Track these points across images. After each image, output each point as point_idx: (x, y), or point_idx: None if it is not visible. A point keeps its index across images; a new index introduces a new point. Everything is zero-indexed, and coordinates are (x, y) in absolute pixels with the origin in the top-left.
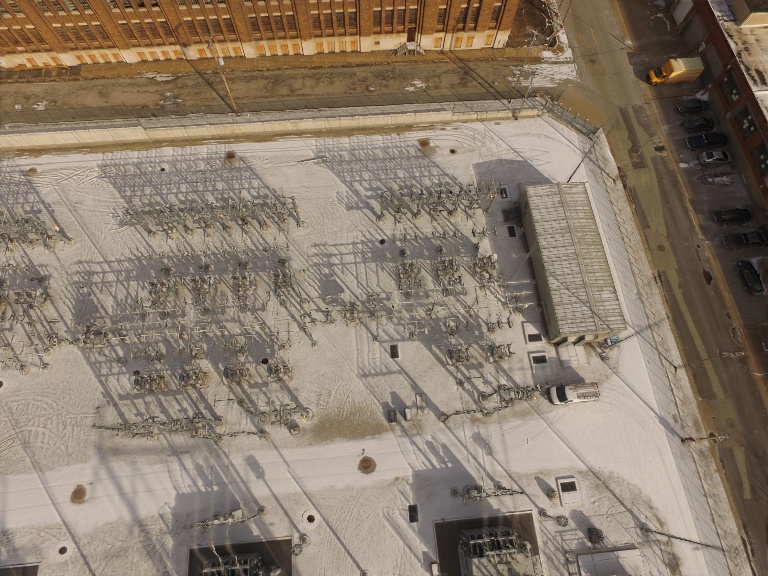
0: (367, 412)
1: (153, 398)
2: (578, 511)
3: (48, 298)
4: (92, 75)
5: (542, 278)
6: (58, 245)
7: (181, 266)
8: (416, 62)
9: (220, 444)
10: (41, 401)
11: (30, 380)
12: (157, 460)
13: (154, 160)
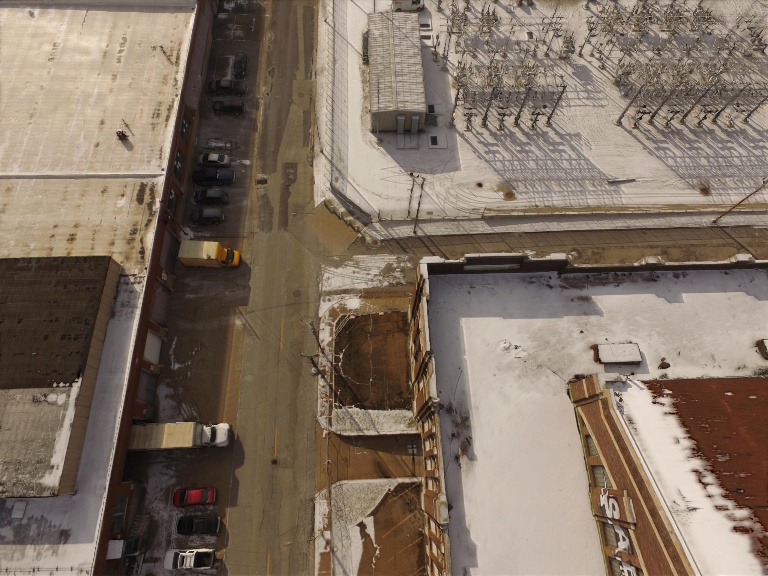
0: (546, 6)
1: None
2: None
3: None
4: None
5: None
6: None
7: None
8: None
9: None
10: (766, 24)
11: None
12: None
13: None
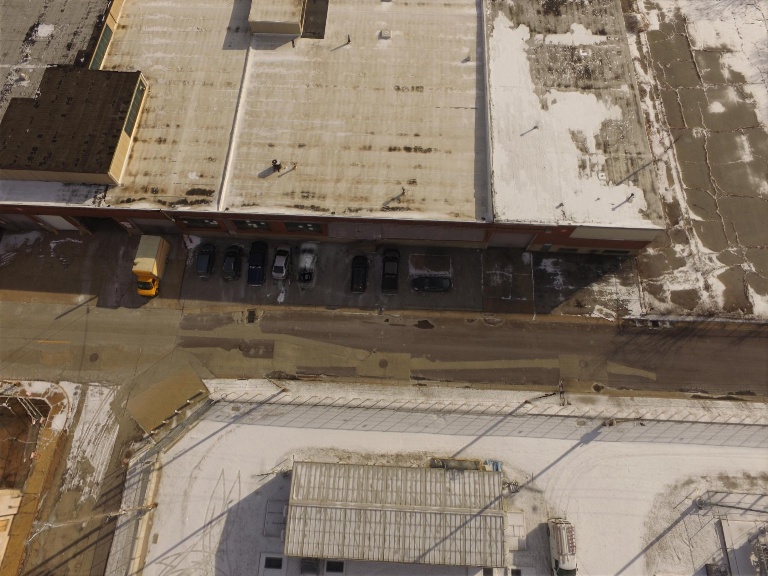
0: None
1: None
2: None
3: None
4: None
5: None
6: None
7: None
8: None
9: None
10: None
11: None
12: None
13: None
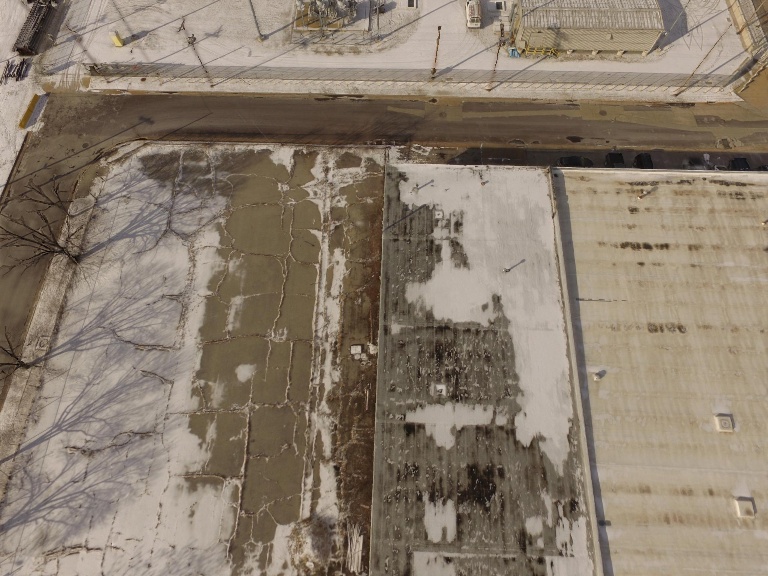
0: None
1: None
2: (395, 6)
3: None
4: None
5: None
6: None
7: None
8: None
9: None
10: None
11: None
12: None
13: None
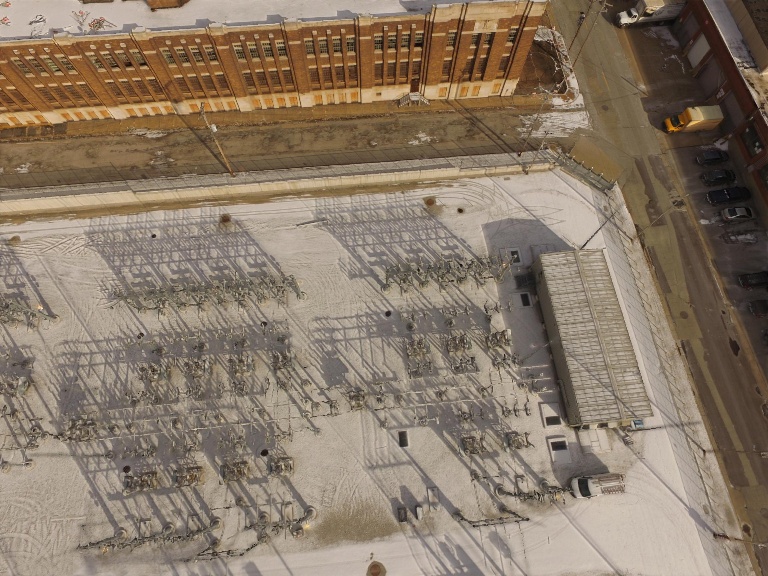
0: (375, 510)
1: (144, 497)
2: None
3: (32, 384)
4: (78, 133)
5: (560, 356)
6: (42, 323)
7: (174, 345)
8: (420, 113)
9: (217, 550)
10: (24, 503)
11: (12, 478)
12: (149, 569)
13: (144, 225)
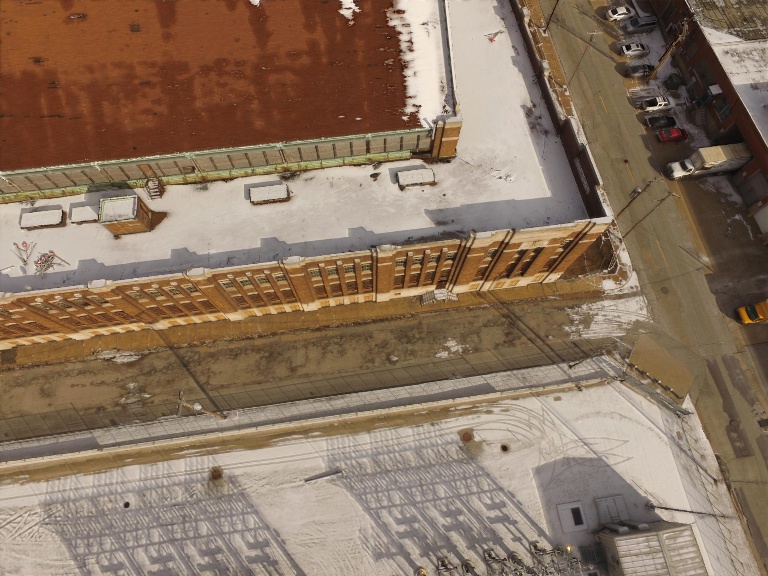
0: None
1: None
2: None
3: None
4: (31, 361)
5: None
6: None
7: None
8: (447, 311)
9: None
10: None
11: None
12: None
13: (115, 489)
